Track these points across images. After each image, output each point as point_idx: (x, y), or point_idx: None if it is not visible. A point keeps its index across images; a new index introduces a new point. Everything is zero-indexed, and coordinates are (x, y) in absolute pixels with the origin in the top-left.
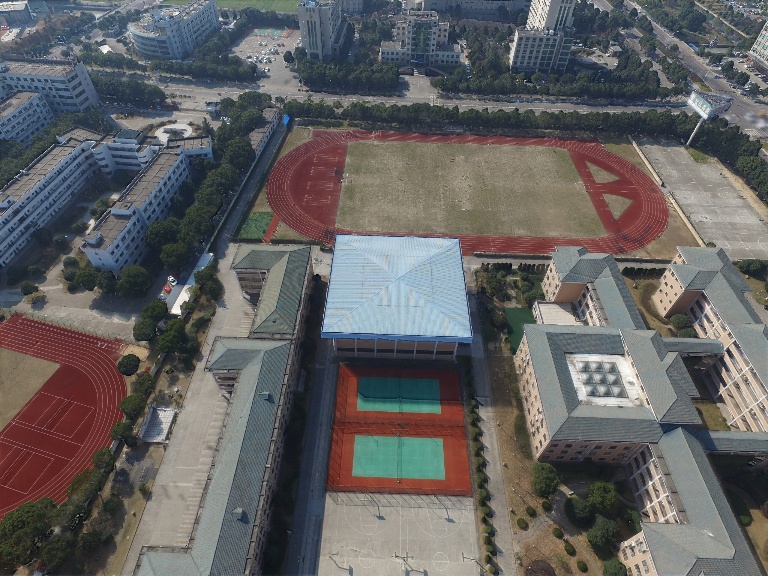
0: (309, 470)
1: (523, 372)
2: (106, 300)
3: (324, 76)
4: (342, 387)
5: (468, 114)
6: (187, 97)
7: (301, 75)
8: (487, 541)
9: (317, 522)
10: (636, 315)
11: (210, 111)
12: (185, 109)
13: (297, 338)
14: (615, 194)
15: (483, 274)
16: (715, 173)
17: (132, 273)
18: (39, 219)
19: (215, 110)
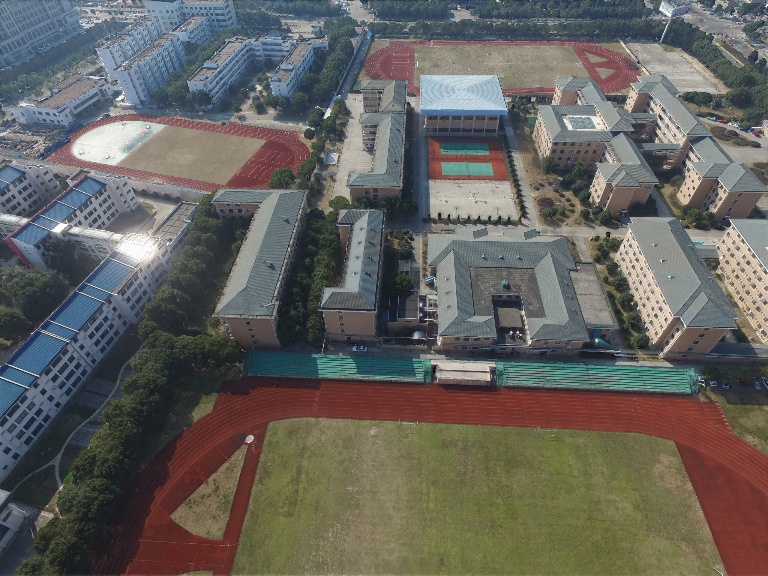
0: (418, 173)
1: (538, 135)
2: (281, 117)
3: (393, 9)
4: (431, 146)
5: (500, 26)
6: (295, 26)
7: (376, 9)
8: (517, 191)
9: (426, 188)
10: (605, 100)
11: (315, 31)
12: (296, 32)
13: None
14: (604, 67)
15: None
16: (678, 56)
17: (301, 95)
18: (228, 81)
19: None
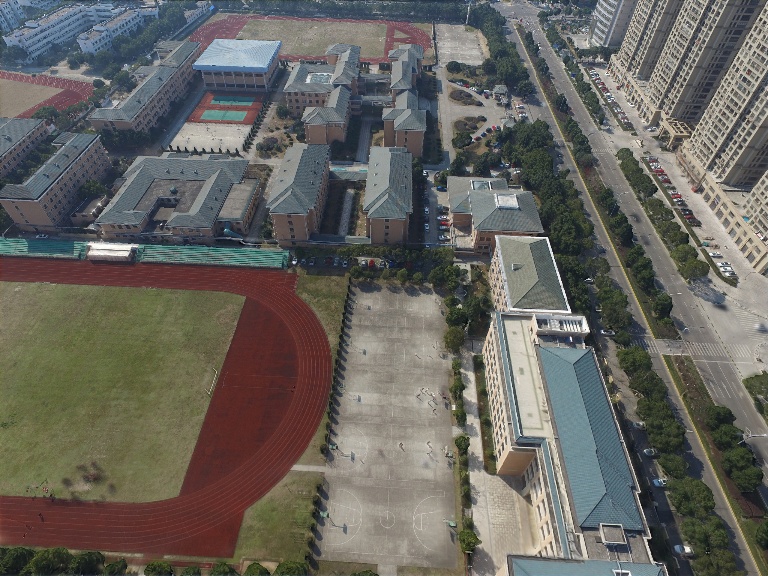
0: (180, 117)
1: None
2: (90, 72)
3: None
4: (205, 98)
5: (327, 4)
6: None
7: None
8: (251, 132)
9: (178, 128)
10: None
11: None
12: (149, 4)
13: (184, 76)
14: (402, 42)
15: None
16: (473, 35)
17: (103, 52)
18: (54, 41)
19: None
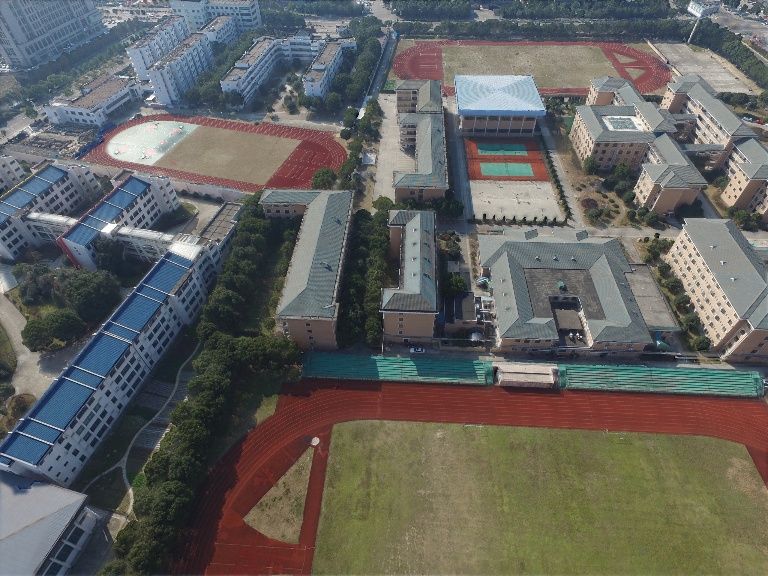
0: (458, 174)
1: (575, 135)
2: (314, 117)
3: (416, 8)
4: (468, 147)
5: (526, 26)
6: (318, 26)
7: (399, 9)
8: (560, 192)
9: (467, 189)
10: (644, 101)
11: (340, 31)
12: (320, 32)
13: None
14: (634, 68)
15: (546, 104)
16: (707, 57)
17: (335, 95)
18: (258, 81)
19: (344, 30)
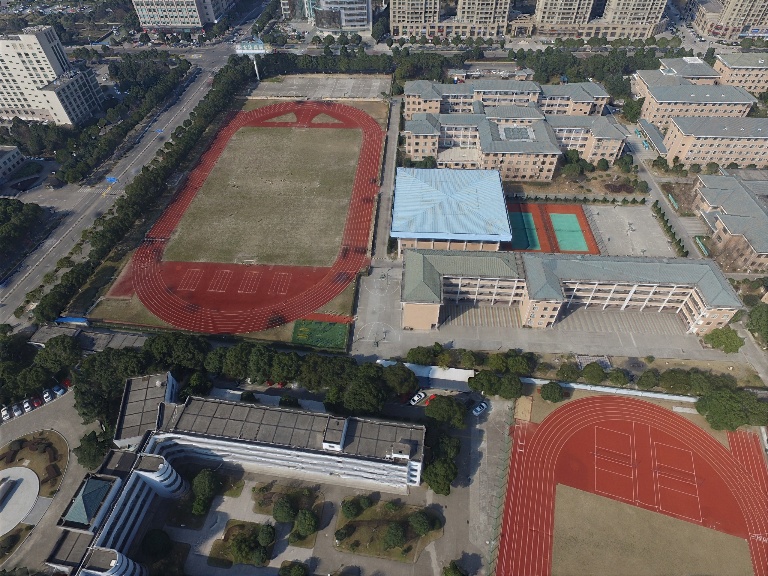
0: None
1: None
2: None
3: None
4: None
5: (171, 159)
6: None
7: None
8: None
9: None
10: None
11: None
12: None
13: None
14: (313, 117)
15: None
16: (297, 79)
17: (448, 401)
18: None
19: None
